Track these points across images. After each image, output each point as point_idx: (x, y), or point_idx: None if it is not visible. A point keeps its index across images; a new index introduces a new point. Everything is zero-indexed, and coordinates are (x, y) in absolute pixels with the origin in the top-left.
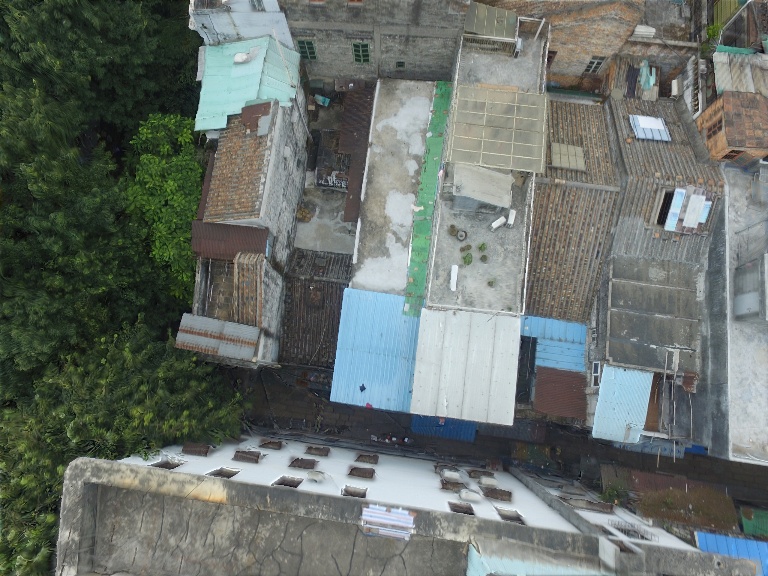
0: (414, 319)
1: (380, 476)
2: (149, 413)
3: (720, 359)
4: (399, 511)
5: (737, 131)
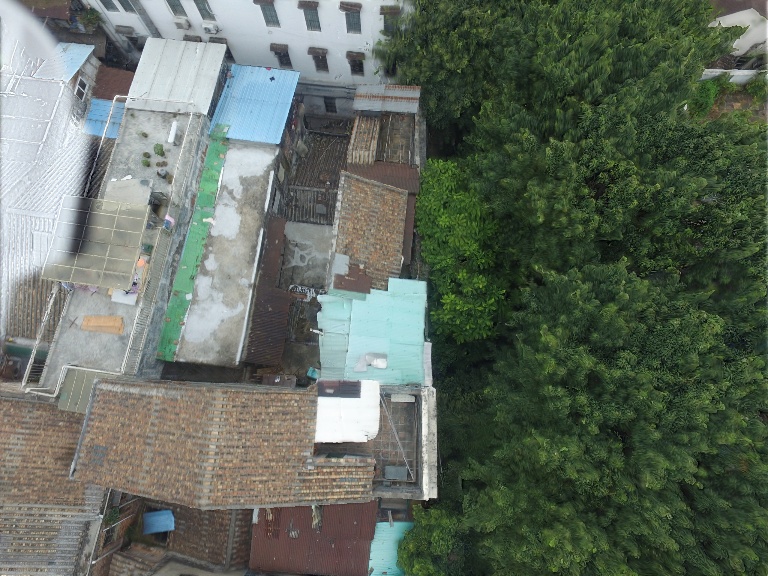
0: (221, 122)
1: (252, 4)
2: (419, 14)
3: None
4: None
5: None
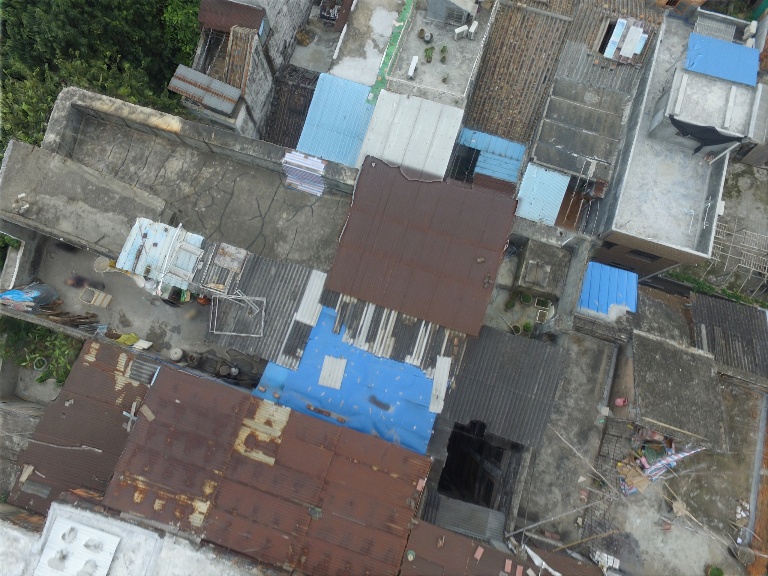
0: None
1: None
2: None
3: (625, 158)
4: (314, 159)
5: None
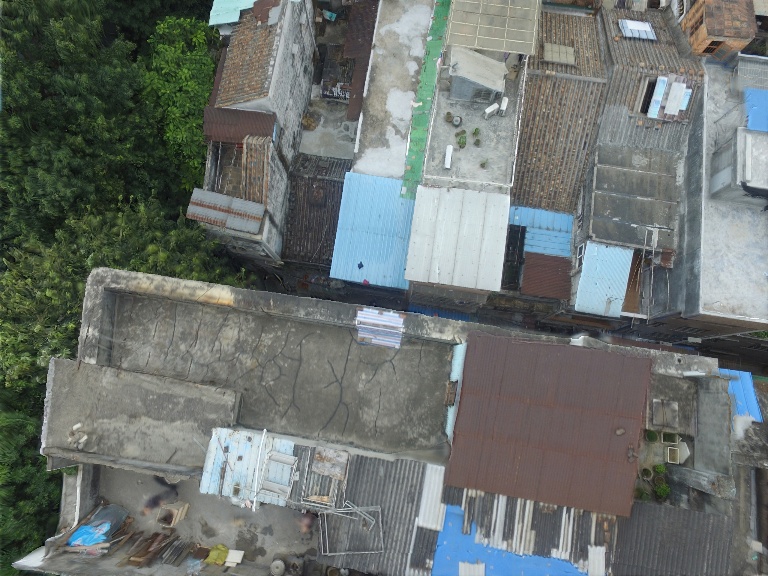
0: (410, 202)
1: None
2: (162, 262)
3: (695, 229)
4: (390, 314)
5: (716, 21)
